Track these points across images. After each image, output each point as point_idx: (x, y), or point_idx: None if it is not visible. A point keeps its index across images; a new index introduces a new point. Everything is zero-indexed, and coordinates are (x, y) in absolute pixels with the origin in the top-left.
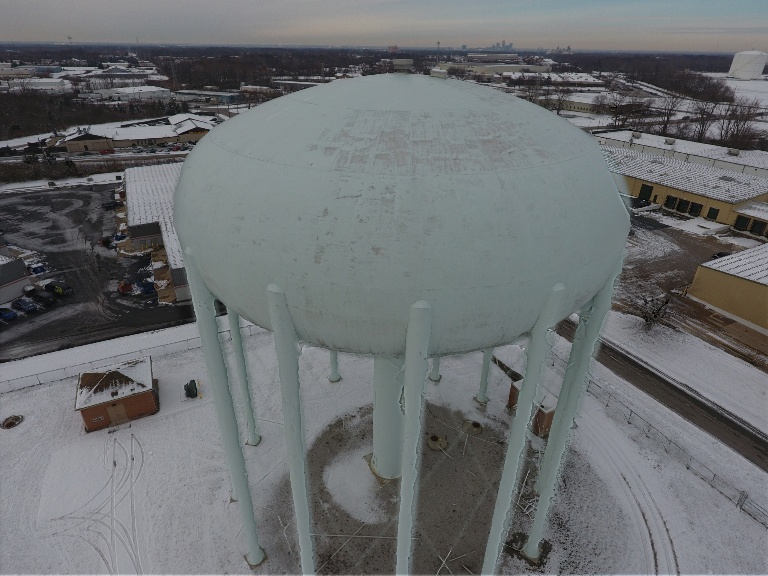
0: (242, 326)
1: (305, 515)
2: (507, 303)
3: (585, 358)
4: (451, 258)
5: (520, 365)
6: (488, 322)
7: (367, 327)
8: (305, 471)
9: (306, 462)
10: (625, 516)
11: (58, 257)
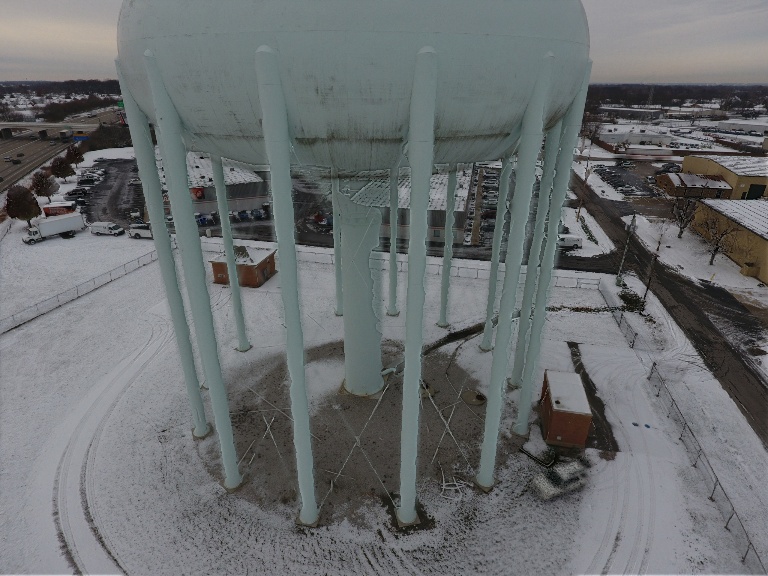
0: None
1: (177, 312)
2: (209, 60)
3: (412, 222)
4: (163, 4)
5: (606, 377)
6: (200, 84)
7: None
8: None
9: (305, 352)
10: (566, 568)
11: (302, 195)
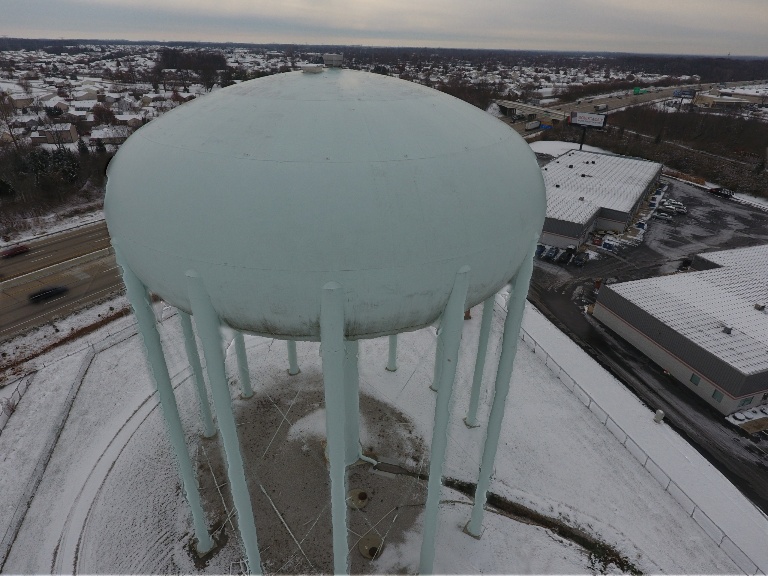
0: (559, 356)
1: None
2: None
3: None
4: None
5: None
6: None
7: None
8: None
9: (361, 395)
10: None
11: (640, 250)
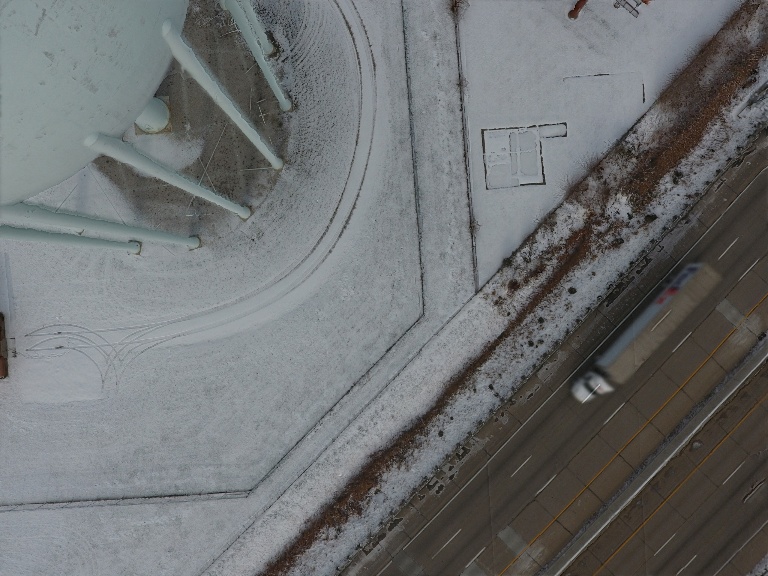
0: None
1: (209, 193)
2: None
3: None
4: None
5: None
6: None
7: (155, 80)
8: (132, 190)
9: (122, 186)
10: None
11: None
